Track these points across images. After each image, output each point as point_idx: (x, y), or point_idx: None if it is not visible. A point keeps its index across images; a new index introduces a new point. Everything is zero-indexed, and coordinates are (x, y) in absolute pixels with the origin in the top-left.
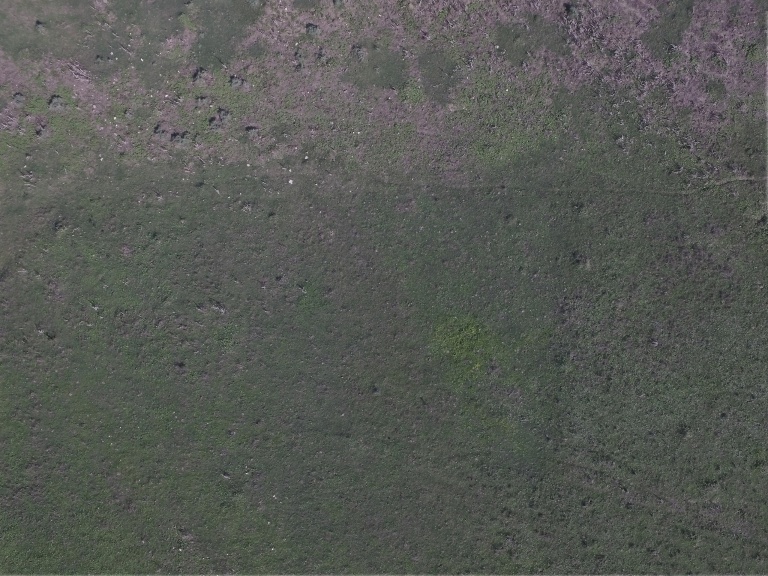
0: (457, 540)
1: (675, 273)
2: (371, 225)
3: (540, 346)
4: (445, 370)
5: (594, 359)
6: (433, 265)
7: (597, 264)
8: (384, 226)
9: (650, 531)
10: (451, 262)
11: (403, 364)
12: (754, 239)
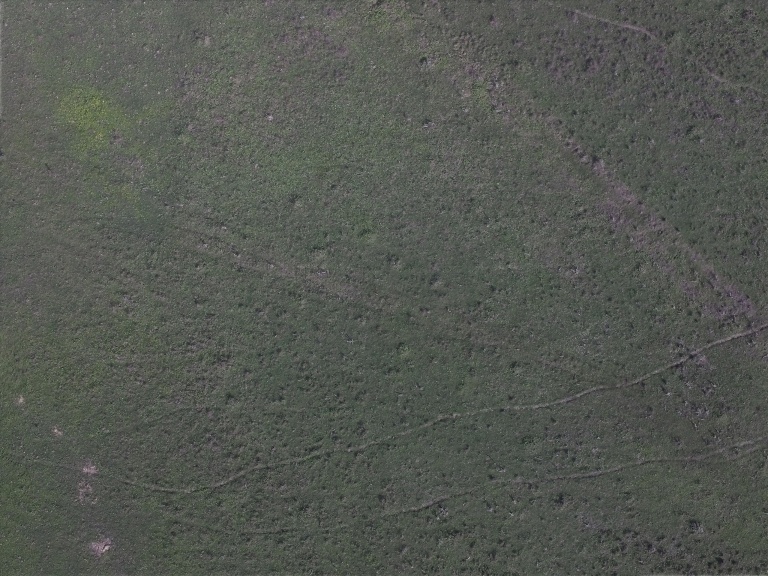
0: (77, 298)
1: (292, 52)
2: (1, 0)
3: (161, 118)
4: (70, 139)
5: (212, 131)
6: (61, 40)
7: (217, 42)
8: (14, 2)
9: (259, 293)
10: (78, 37)
11: (29, 131)
12: (368, 21)
